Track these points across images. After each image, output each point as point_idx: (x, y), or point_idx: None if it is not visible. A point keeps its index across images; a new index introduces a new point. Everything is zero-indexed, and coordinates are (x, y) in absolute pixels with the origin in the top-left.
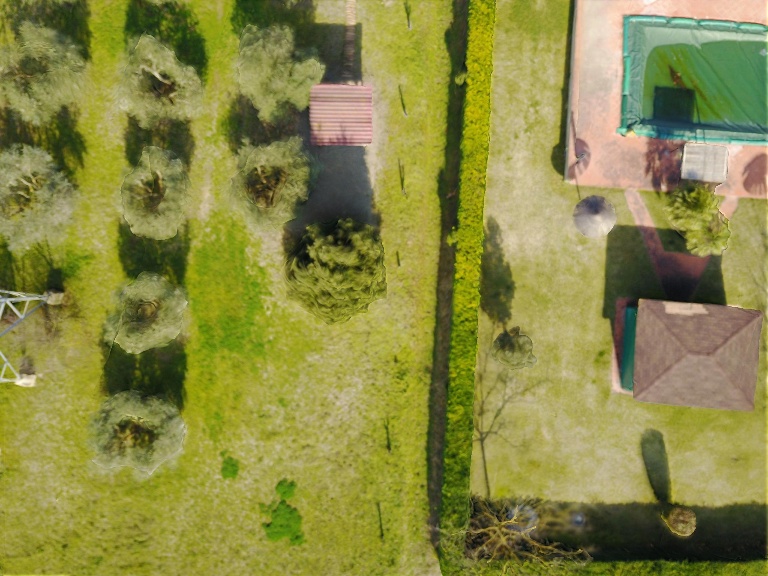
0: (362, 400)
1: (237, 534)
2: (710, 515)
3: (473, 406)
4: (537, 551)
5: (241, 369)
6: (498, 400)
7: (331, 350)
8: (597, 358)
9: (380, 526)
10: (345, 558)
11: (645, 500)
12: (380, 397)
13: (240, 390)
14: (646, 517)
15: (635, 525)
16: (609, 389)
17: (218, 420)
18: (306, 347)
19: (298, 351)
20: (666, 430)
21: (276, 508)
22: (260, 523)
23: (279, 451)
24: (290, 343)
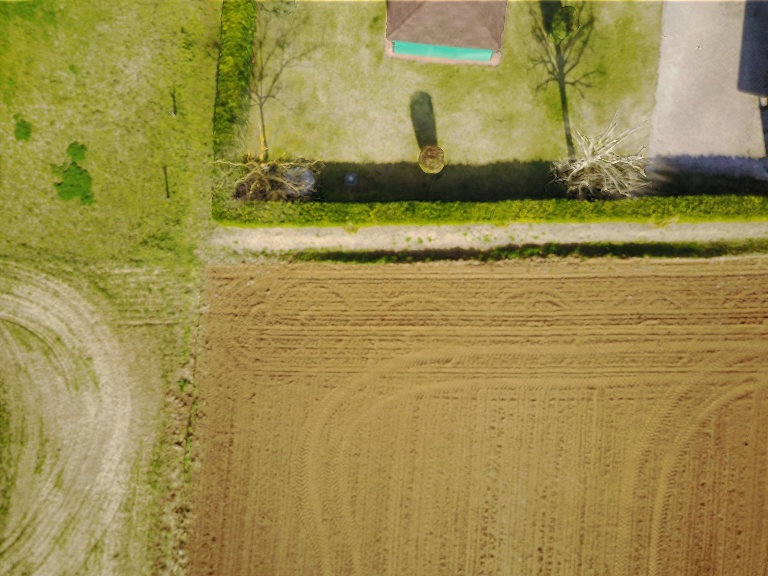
0: (149, 69)
1: (30, 193)
2: (473, 173)
3: (253, 73)
4: (302, 197)
5: (32, 36)
6: (276, 66)
7: (119, 20)
8: (371, 24)
9: (166, 189)
10: (133, 218)
11: (413, 160)
12: (166, 66)
13: (32, 56)
14: (413, 176)
15: (403, 184)
16: (381, 54)
17: (11, 85)
18: (95, 17)
19: (88, 20)
20: (434, 93)
21: (67, 169)
22: (52, 183)
23: (70, 116)
24: (80, 12)
